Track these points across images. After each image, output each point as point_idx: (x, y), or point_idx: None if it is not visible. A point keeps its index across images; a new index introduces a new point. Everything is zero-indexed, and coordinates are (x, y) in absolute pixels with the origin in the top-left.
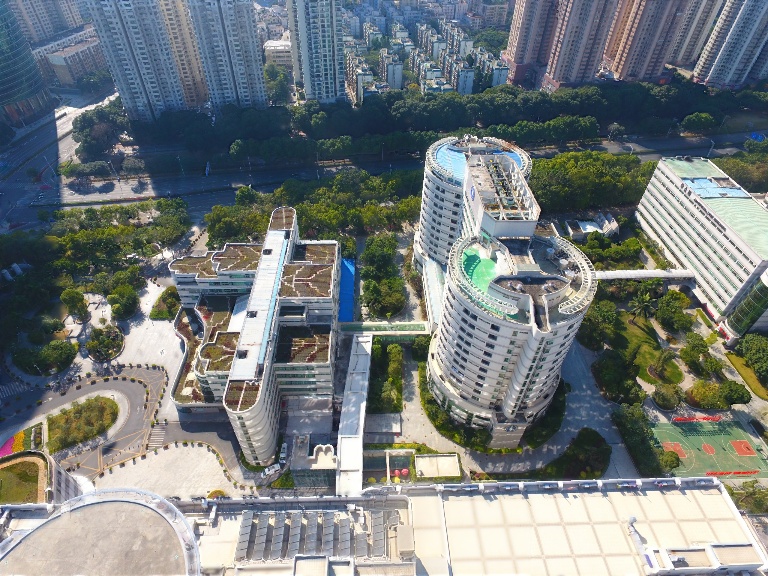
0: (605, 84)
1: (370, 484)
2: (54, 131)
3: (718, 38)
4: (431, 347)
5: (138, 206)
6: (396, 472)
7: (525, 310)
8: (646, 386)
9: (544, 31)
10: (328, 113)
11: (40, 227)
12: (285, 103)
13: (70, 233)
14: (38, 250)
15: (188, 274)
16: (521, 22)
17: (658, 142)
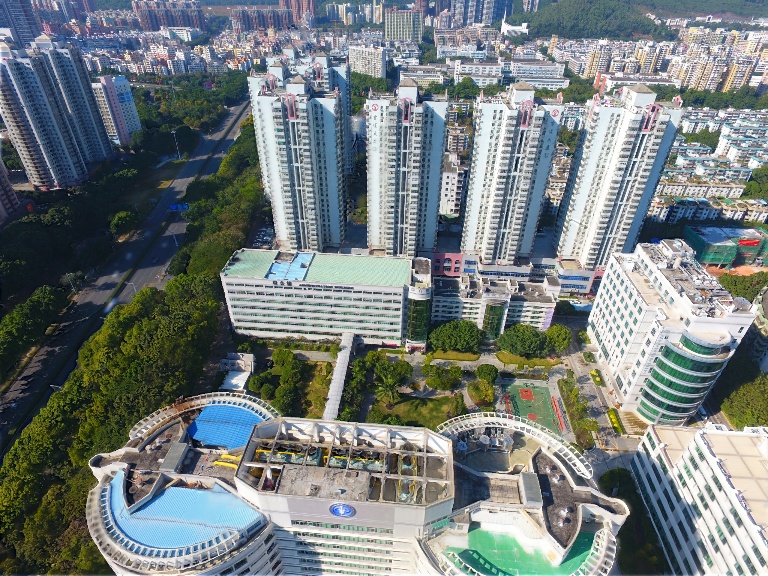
0: None
1: None
2: None
3: (28, 144)
4: None
5: None
6: None
7: None
8: None
9: None
10: None
11: None
12: None
13: None
14: None
15: None
16: None
17: (117, 261)
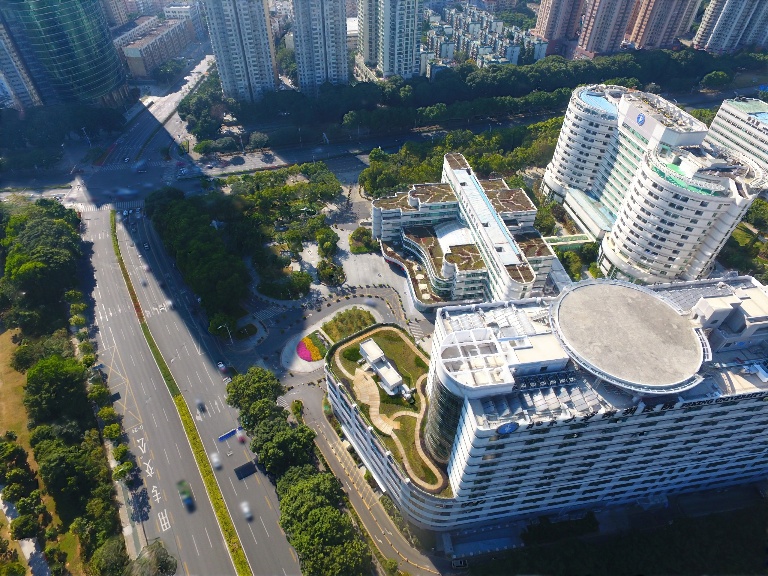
0: (634, 52)
1: None
2: (152, 117)
3: (715, 10)
4: (609, 245)
5: (287, 170)
6: None
7: None
8: None
9: (572, 9)
10: (412, 86)
11: (200, 195)
12: (356, 83)
13: (257, 191)
14: (233, 207)
15: (392, 210)
16: (552, 2)
17: (685, 98)
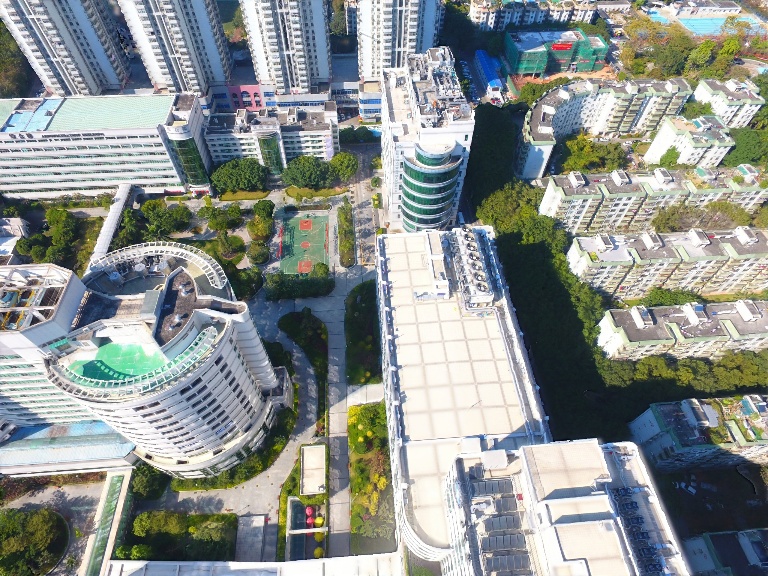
0: None
1: (326, 553)
2: None
3: None
4: (166, 464)
5: None
6: (309, 522)
7: (205, 322)
8: (242, 265)
9: None
10: None
11: None
12: None
13: None
14: None
15: None
16: None
17: None
